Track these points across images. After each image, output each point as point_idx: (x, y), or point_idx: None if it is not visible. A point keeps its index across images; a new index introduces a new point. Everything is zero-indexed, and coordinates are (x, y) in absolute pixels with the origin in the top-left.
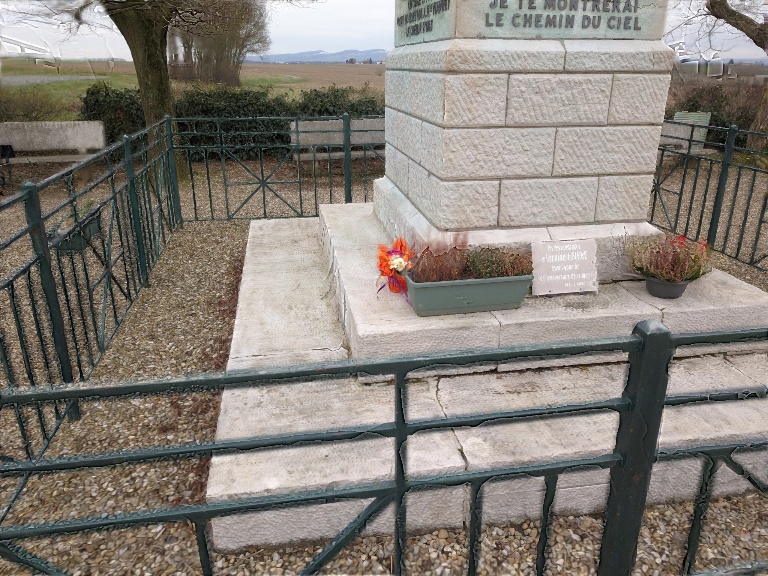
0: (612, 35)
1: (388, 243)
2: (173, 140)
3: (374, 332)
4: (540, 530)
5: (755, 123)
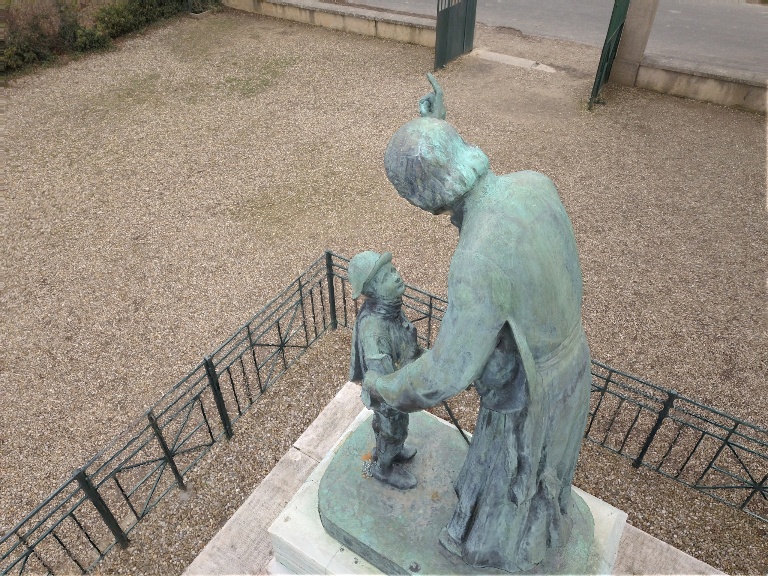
0: None
1: None
2: None
3: None
4: None
5: None
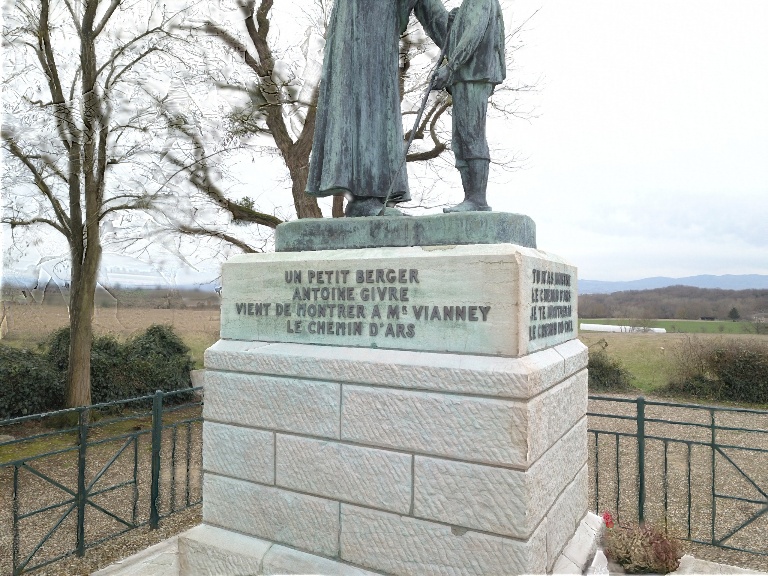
0: (565, 338)
1: None
2: None
3: None
4: None
5: None
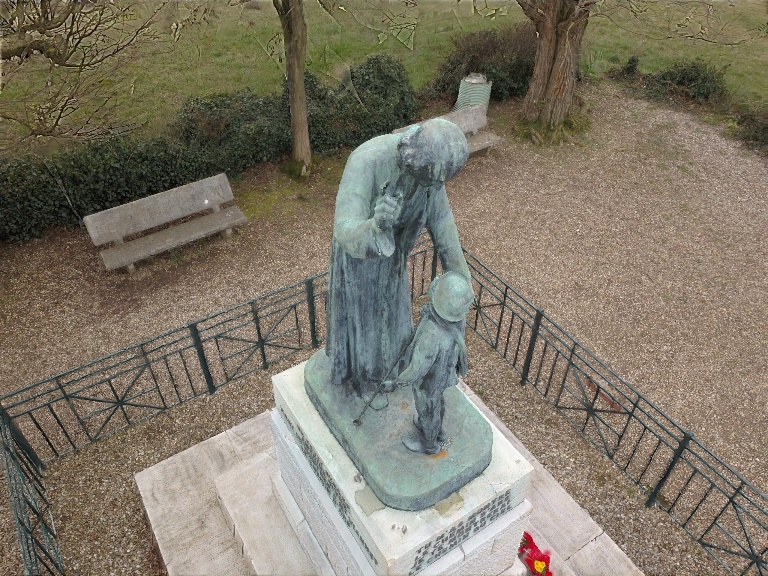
0: None
1: None
2: (7, 411)
3: None
4: None
5: (529, 96)
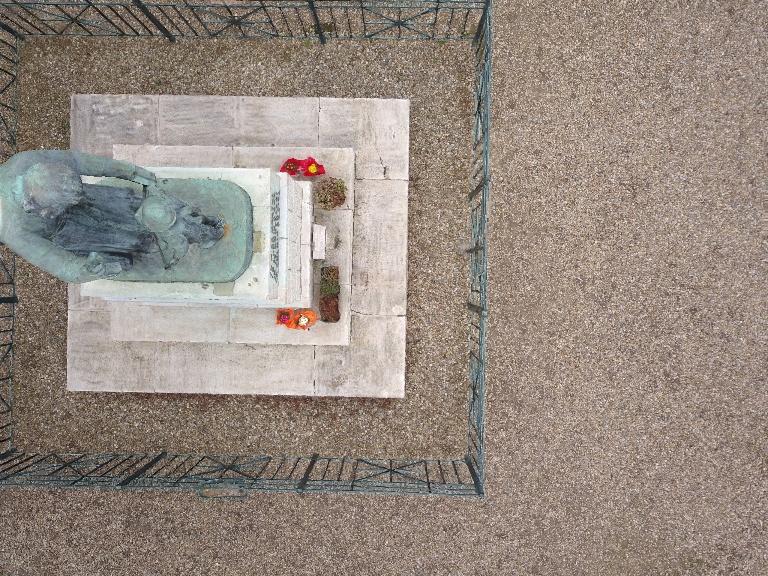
0: None
1: (228, 310)
2: None
3: (347, 339)
4: (410, 290)
5: None
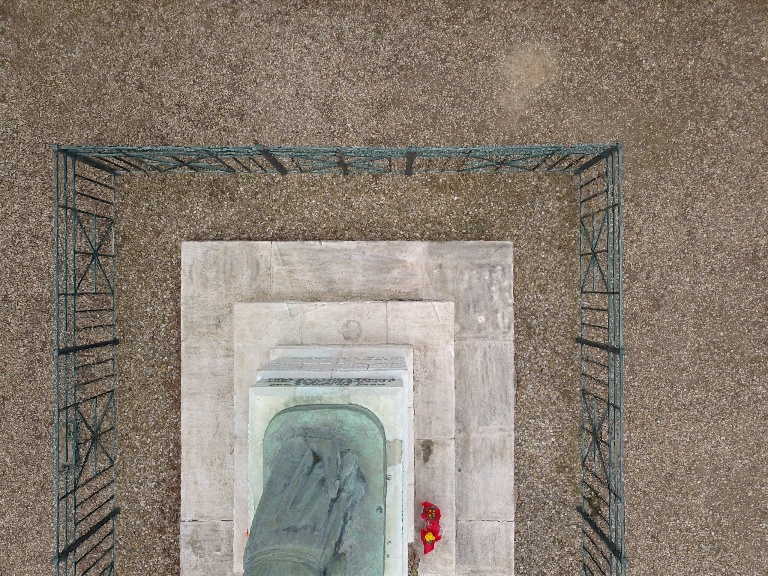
0: None
1: None
2: None
3: (241, 571)
4: None
5: None
